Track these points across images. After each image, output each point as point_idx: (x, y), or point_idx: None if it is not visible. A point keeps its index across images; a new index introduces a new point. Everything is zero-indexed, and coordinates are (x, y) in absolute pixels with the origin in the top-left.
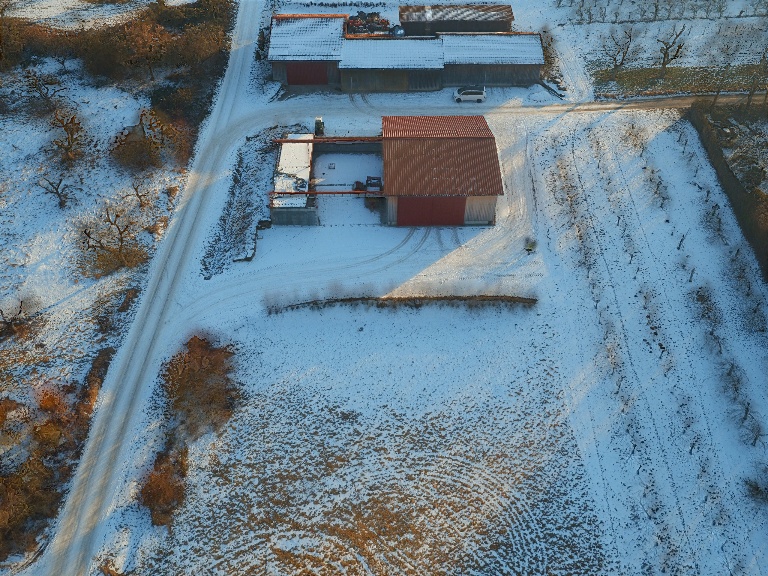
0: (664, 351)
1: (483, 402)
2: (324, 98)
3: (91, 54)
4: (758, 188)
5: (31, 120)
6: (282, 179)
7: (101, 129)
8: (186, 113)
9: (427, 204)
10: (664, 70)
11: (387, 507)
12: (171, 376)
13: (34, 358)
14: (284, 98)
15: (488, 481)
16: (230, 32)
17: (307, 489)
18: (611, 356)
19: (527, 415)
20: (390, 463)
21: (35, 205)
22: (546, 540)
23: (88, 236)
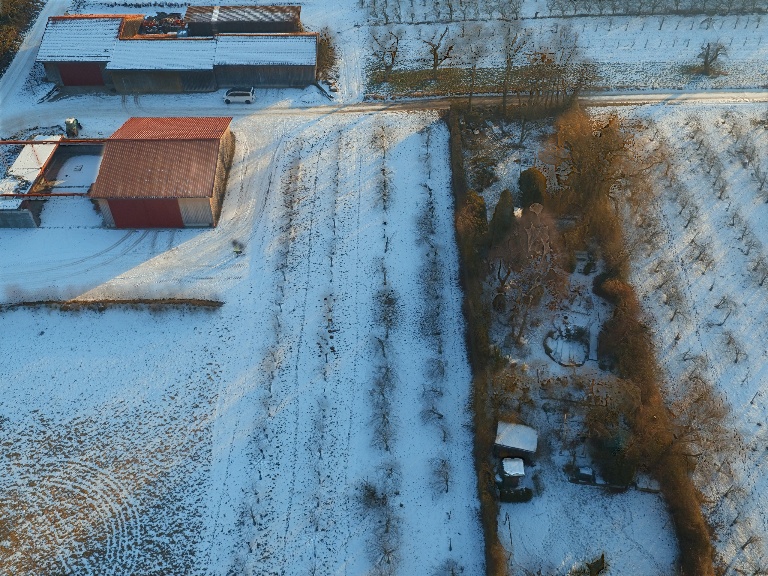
0: (333, 355)
1: (134, 407)
2: (96, 99)
3: None
4: (487, 190)
5: None
6: (7, 181)
7: None
8: None
9: (139, 206)
10: (436, 71)
11: None
12: None
13: None
14: (56, 99)
15: (108, 487)
16: (24, 32)
17: None
18: (278, 360)
19: (173, 420)
20: (17, 469)
21: None
22: (142, 547)
23: None
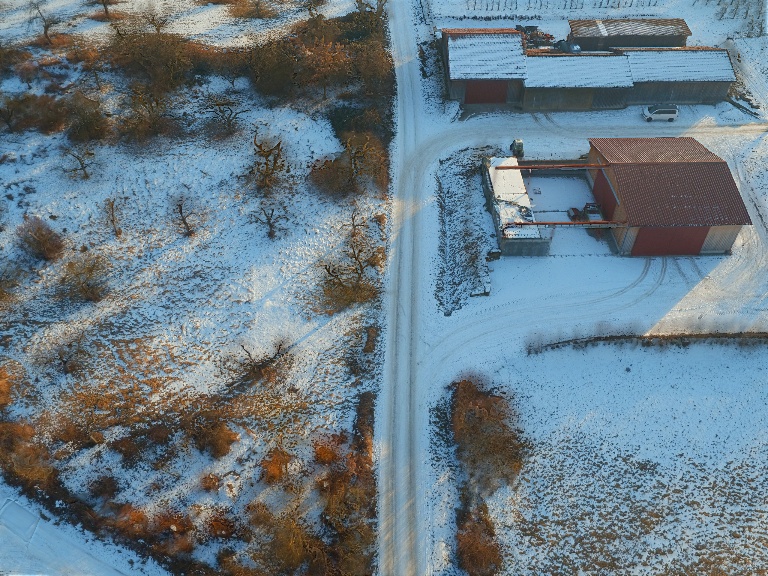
0: None
1: None
2: (506, 118)
3: (267, 74)
4: None
5: (212, 144)
6: (504, 207)
7: (288, 153)
8: None
9: (668, 234)
10: None
11: (722, 568)
12: (442, 423)
13: (290, 404)
14: (465, 118)
15: None
16: (388, 48)
17: (630, 549)
18: None
19: None
20: (708, 519)
21: (242, 236)
22: None
23: None
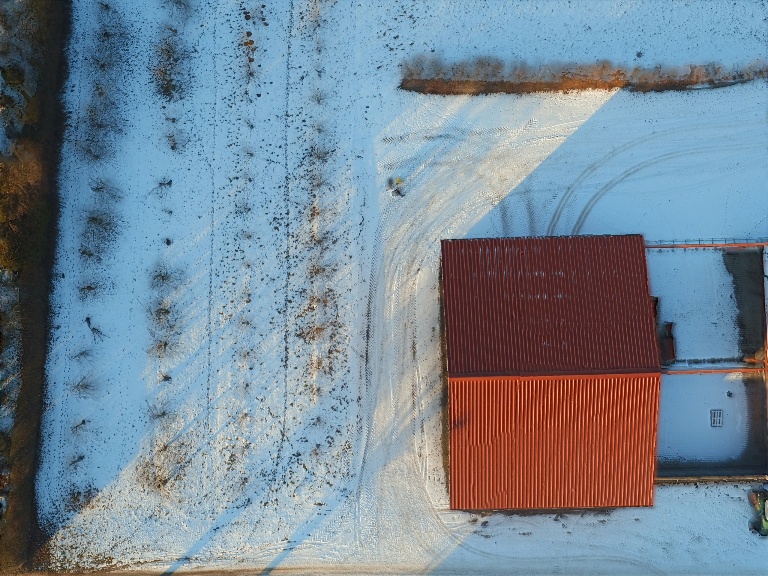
0: (246, 6)
1: None
2: None
3: None
4: None
5: None
6: None
7: None
8: None
9: None
10: None
11: None
12: None
13: None
14: None
15: None
16: None
17: None
18: (316, 1)
19: None
20: None
21: None
22: None
23: None
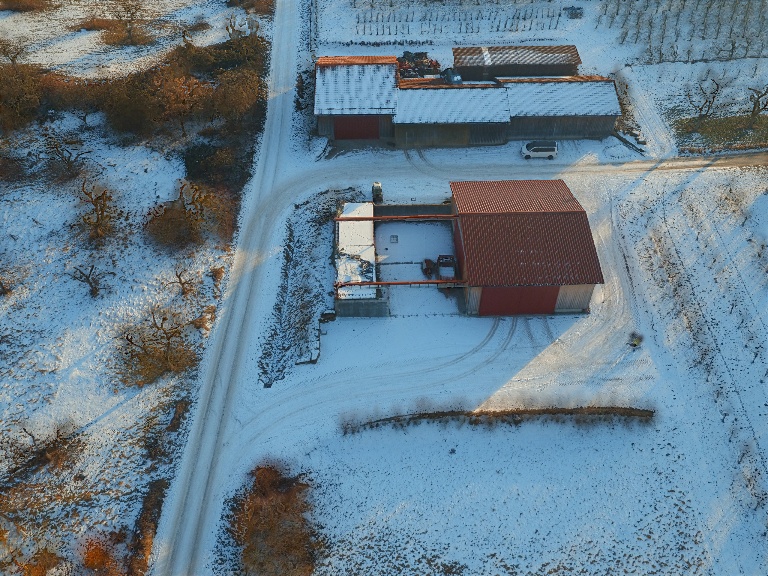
0: None
1: (608, 548)
2: (377, 155)
3: (117, 110)
4: None
5: (52, 188)
6: (345, 262)
7: (132, 198)
8: (225, 176)
9: (515, 293)
10: (753, 120)
11: None
12: (236, 517)
13: (73, 494)
14: (332, 156)
15: None
16: (265, 77)
17: None
18: (750, 485)
19: (663, 566)
20: None
21: (62, 294)
22: None
23: (130, 341)
